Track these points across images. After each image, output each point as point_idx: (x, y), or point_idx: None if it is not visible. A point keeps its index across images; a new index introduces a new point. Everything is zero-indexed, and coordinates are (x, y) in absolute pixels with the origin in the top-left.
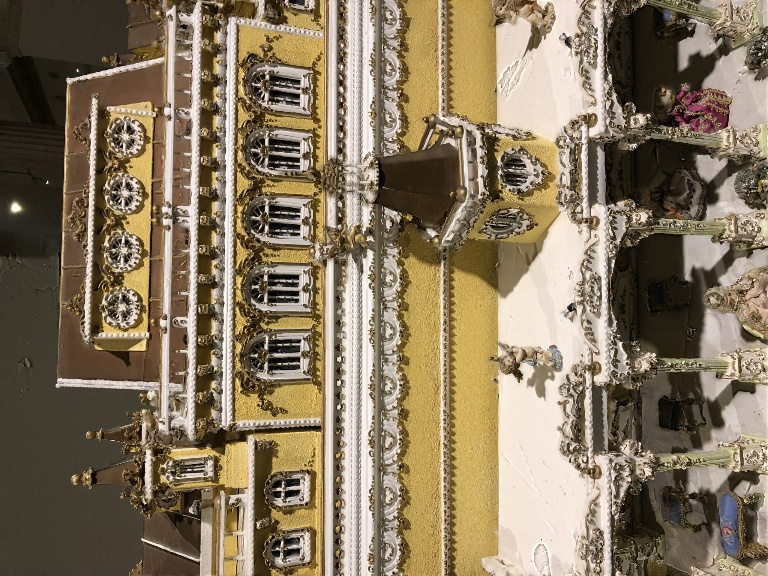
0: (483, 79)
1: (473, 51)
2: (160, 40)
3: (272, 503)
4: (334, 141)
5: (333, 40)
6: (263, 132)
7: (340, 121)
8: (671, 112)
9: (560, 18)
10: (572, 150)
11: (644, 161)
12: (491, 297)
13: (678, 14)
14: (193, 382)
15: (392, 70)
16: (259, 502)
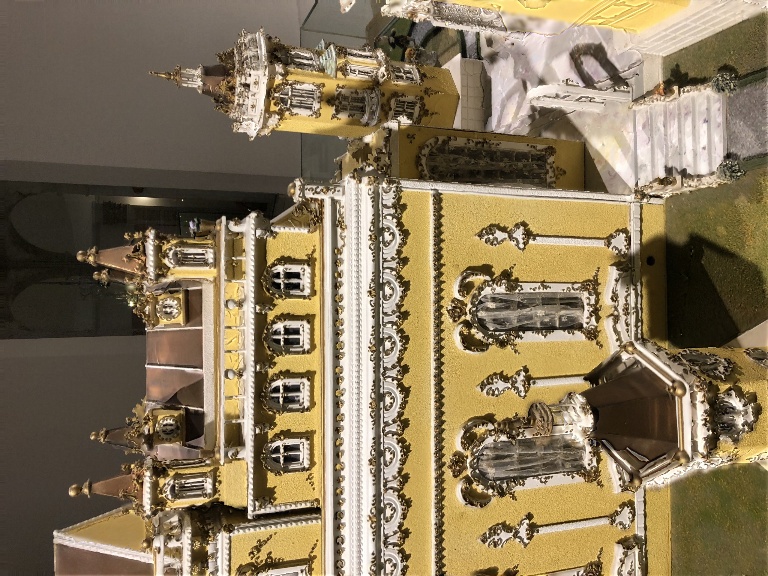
0: None
1: None
2: None
3: None
4: None
5: None
6: None
7: None
8: None
9: None
10: None
11: None
12: None
13: None
14: None
15: None
16: None
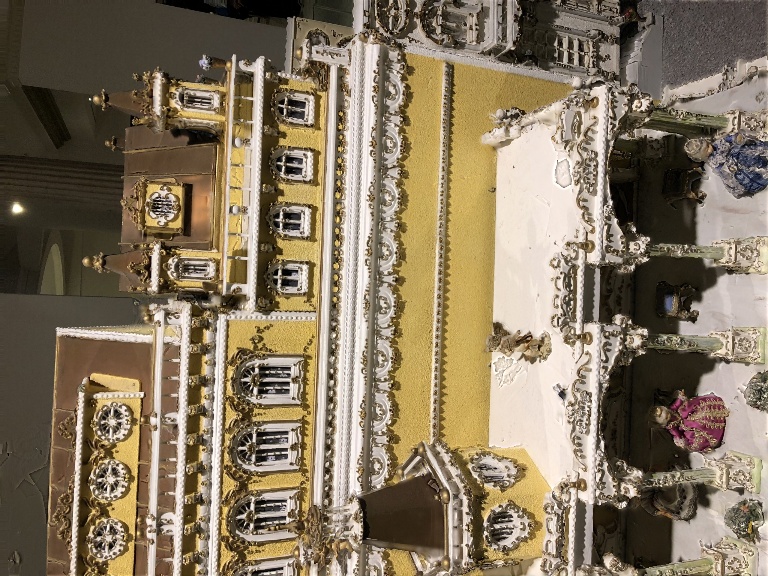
0: (478, 352)
1: (469, 325)
2: (150, 309)
3: None
4: (322, 442)
5: (325, 336)
6: (251, 428)
7: (329, 415)
8: (666, 426)
9: (556, 355)
10: (559, 516)
11: (639, 423)
12: (476, 575)
13: (677, 351)
14: None
15: (384, 361)
16: None
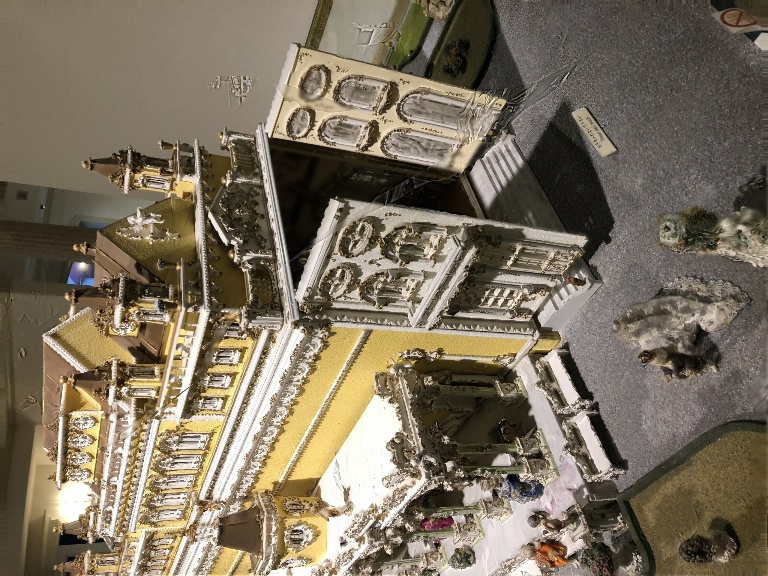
0: (331, 445)
1: (329, 437)
2: None
3: (151, 545)
4: (212, 475)
5: (224, 442)
6: None
7: None
8: None
9: None
10: None
11: None
12: None
13: None
14: (113, 526)
15: None
16: (145, 543)
